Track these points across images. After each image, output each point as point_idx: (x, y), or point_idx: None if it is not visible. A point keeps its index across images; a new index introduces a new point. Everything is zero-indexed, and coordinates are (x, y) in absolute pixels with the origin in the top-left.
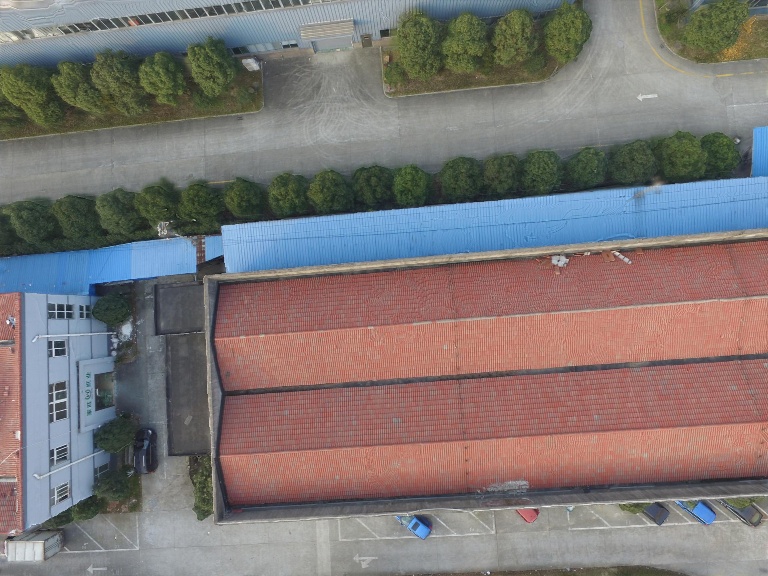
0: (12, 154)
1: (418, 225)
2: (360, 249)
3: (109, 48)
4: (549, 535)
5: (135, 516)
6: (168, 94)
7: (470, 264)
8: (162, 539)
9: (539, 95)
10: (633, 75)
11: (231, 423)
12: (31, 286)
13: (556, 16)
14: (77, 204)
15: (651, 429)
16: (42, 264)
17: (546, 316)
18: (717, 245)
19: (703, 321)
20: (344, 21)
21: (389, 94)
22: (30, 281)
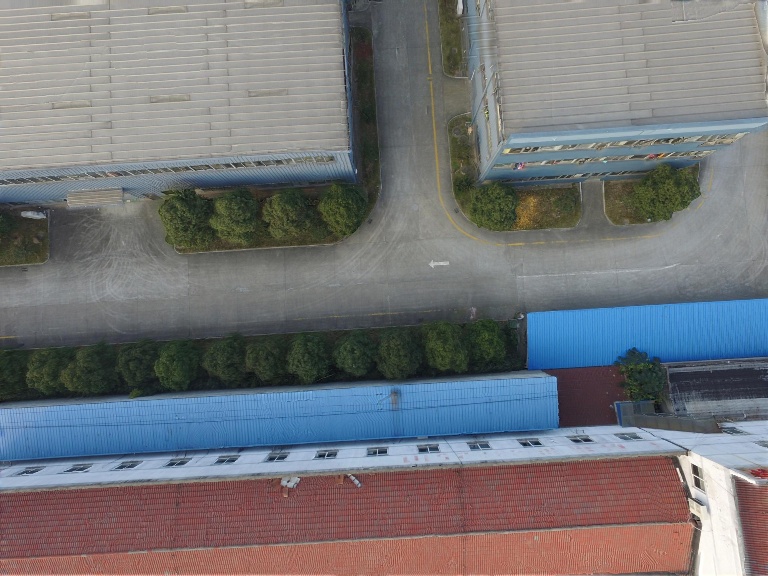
0: None
1: (173, 417)
2: (114, 439)
3: None
4: None
5: None
6: None
7: None
8: None
9: (331, 258)
10: (426, 240)
11: None
12: None
13: (324, 198)
14: None
15: None
16: None
17: (264, 548)
18: None
19: (435, 543)
20: (113, 189)
21: (179, 250)
22: None
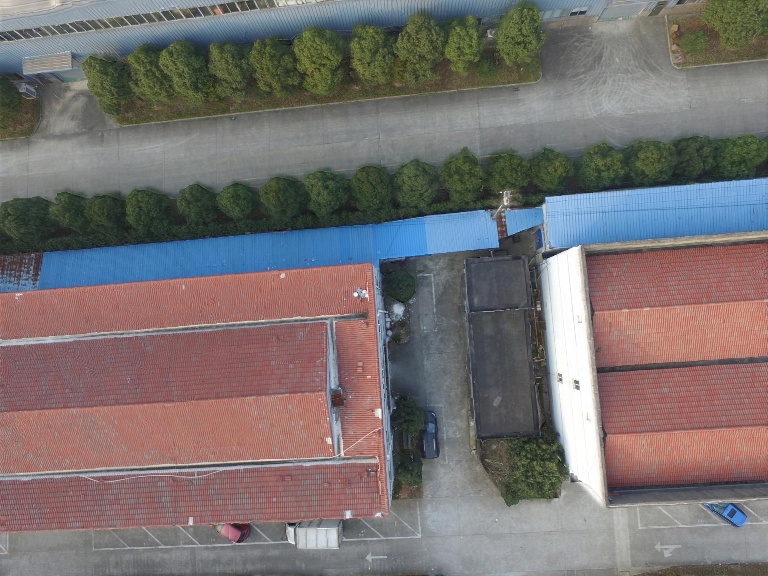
0: (269, 126)
1: (760, 197)
2: (696, 222)
3: (402, 12)
4: None
5: (415, 502)
6: (468, 61)
7: None
8: (446, 526)
9: None
10: None
11: (608, 401)
12: (314, 261)
13: None
14: (382, 174)
15: None
16: (322, 239)
17: None
18: None
19: None
20: None
21: (678, 65)
22: (312, 256)
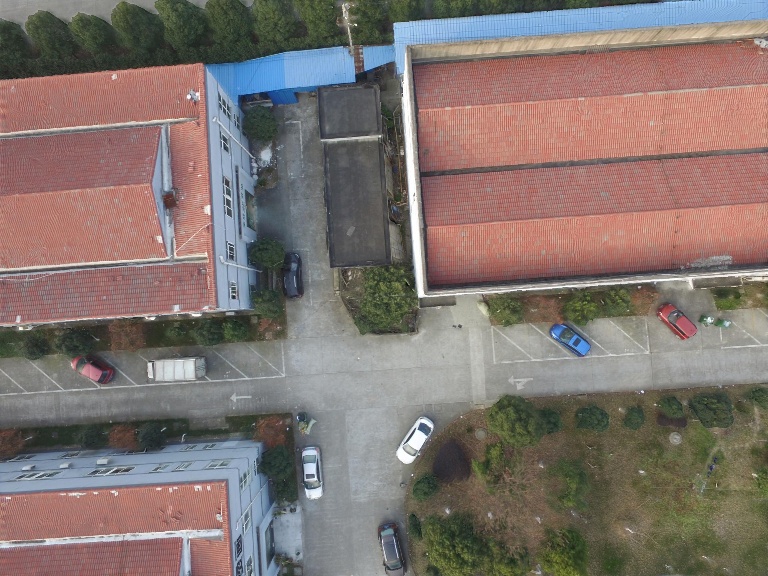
0: None
1: (598, 25)
2: None
3: None
4: (702, 354)
5: (280, 343)
6: None
7: (668, 48)
8: (309, 366)
9: None
10: None
11: (433, 199)
12: None
13: None
14: (235, 0)
15: None
16: None
17: (757, 88)
18: None
19: None
20: None
21: None
22: None
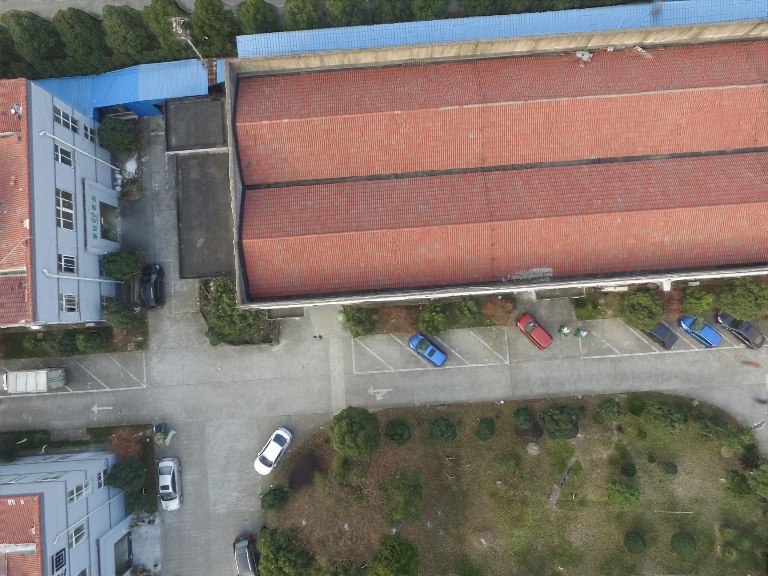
0: None
1: (439, 38)
2: None
3: None
4: (562, 364)
5: (142, 354)
6: None
7: (495, 61)
8: (170, 377)
9: None
10: None
11: (253, 212)
12: None
13: None
14: (81, 14)
15: (673, 208)
16: None
17: (572, 101)
18: (735, 43)
19: (720, 118)
20: None
21: None
22: None
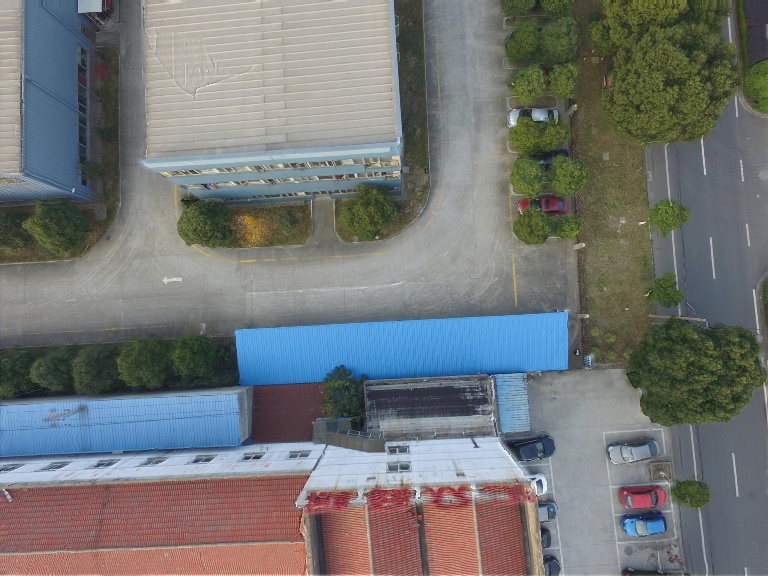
0: None
1: None
2: None
3: None
4: None
5: None
6: None
7: None
8: None
9: (70, 273)
10: (161, 257)
11: None
12: None
13: None
14: None
15: None
16: None
17: None
18: None
19: None
20: None
21: None
22: None
